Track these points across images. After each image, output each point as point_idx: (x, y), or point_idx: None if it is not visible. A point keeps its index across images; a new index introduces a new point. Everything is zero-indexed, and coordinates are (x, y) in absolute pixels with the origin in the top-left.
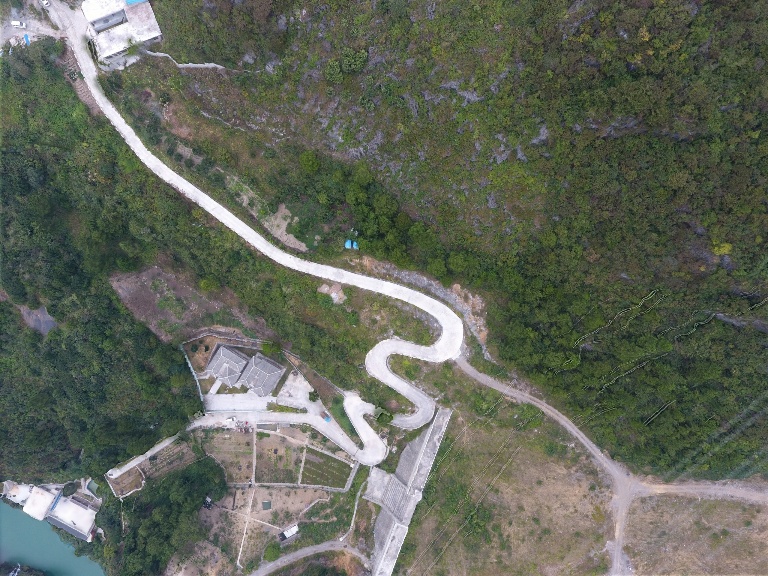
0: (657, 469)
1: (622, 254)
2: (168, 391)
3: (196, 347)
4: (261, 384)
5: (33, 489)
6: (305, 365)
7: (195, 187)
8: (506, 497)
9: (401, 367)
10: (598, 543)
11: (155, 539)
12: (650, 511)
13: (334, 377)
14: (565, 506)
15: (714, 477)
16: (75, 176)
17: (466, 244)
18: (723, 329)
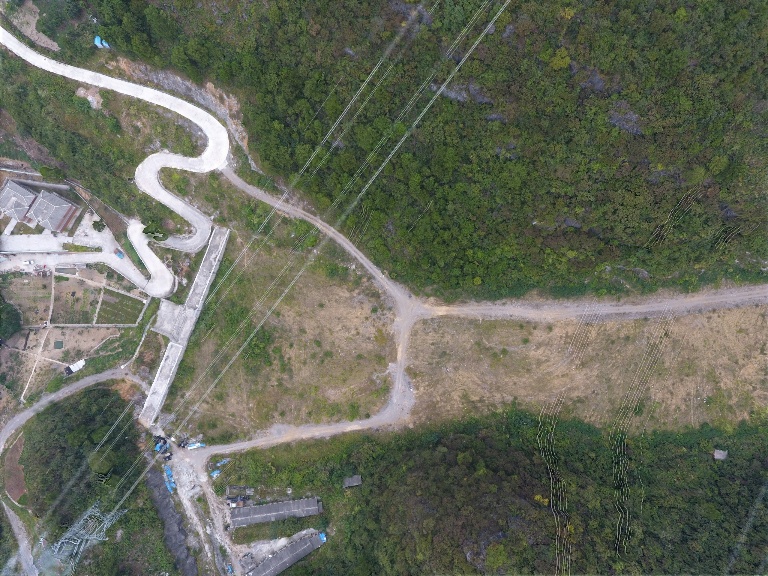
0: (436, 289)
1: (334, 18)
2: None
3: None
4: (48, 216)
5: None
6: (95, 199)
7: None
8: (288, 320)
9: (171, 181)
10: (380, 365)
11: None
12: (431, 332)
13: None
14: (347, 328)
15: (492, 296)
16: None
17: (207, 33)
18: (451, 107)
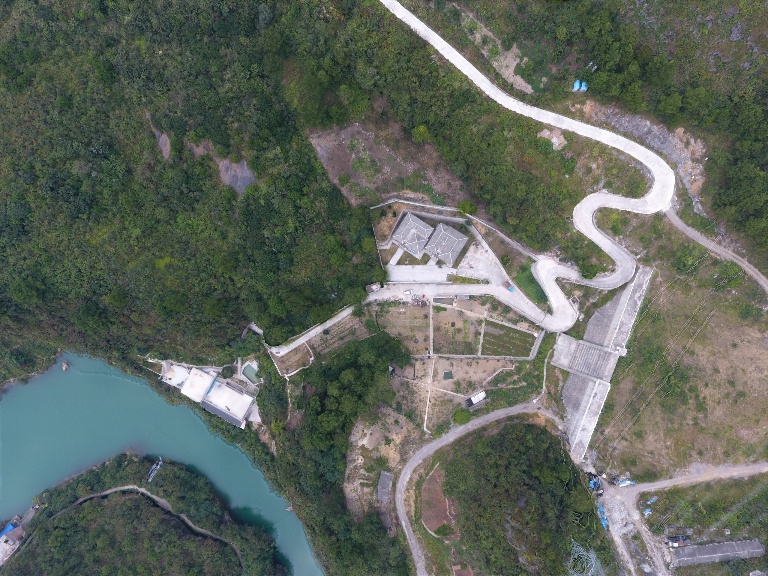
0: None
1: None
2: (349, 260)
3: None
4: (450, 249)
5: (192, 370)
6: (492, 232)
7: (426, 26)
8: (702, 359)
9: (608, 221)
10: None
11: (350, 397)
12: None
13: (535, 235)
14: (760, 369)
15: None
16: (306, 13)
17: (700, 81)
18: None
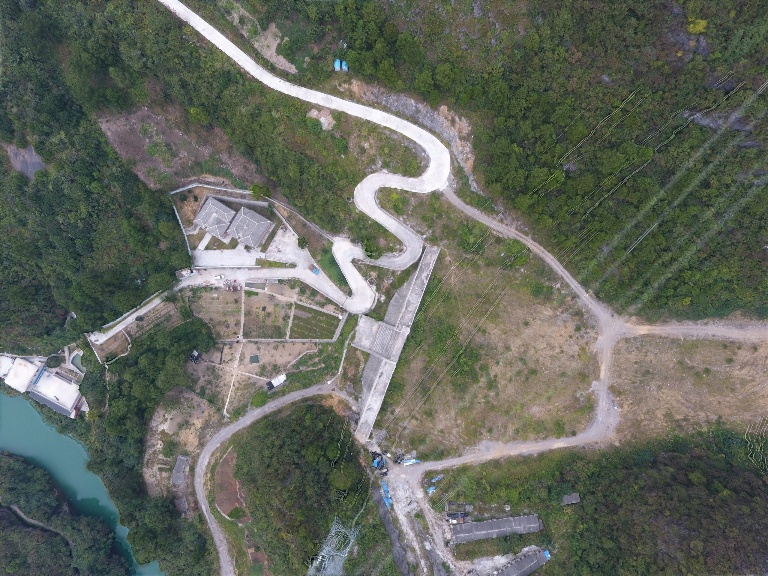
0: (641, 308)
1: (603, 47)
2: (156, 246)
3: (185, 196)
4: (250, 233)
5: (16, 360)
6: (294, 216)
7: (186, 7)
8: (493, 338)
9: (389, 200)
10: (584, 383)
11: (141, 381)
12: (634, 351)
13: None
14: (551, 346)
15: (696, 316)
16: None
17: (452, 58)
18: (701, 134)
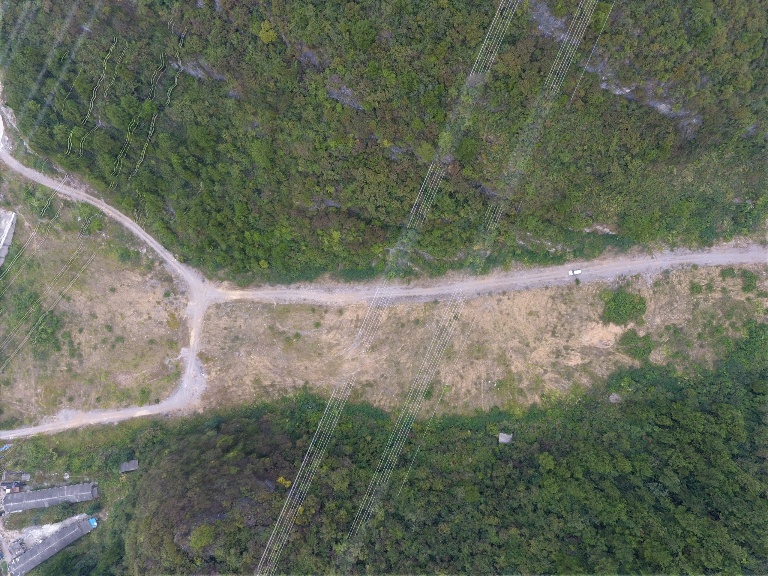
0: (228, 273)
1: None
2: None
3: None
4: None
5: None
6: None
7: None
8: (78, 305)
9: None
10: (172, 350)
11: None
12: (224, 316)
13: None
14: (139, 313)
15: (285, 280)
16: None
17: None
18: None
